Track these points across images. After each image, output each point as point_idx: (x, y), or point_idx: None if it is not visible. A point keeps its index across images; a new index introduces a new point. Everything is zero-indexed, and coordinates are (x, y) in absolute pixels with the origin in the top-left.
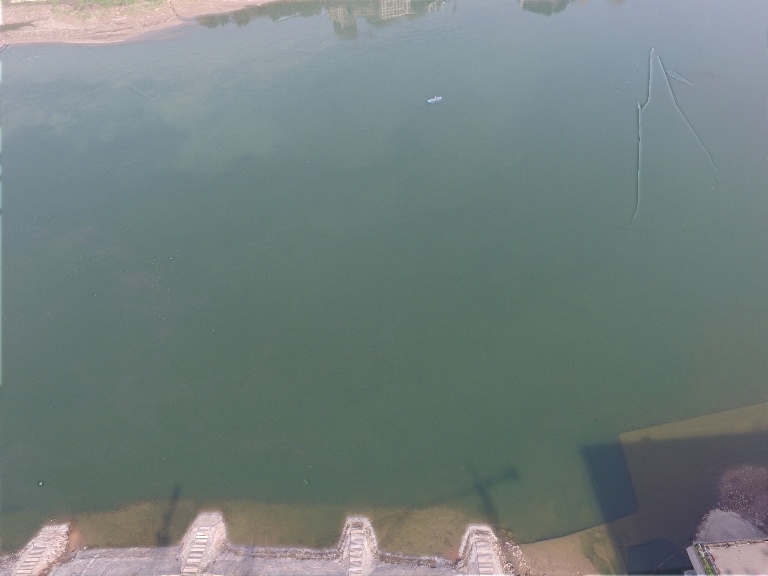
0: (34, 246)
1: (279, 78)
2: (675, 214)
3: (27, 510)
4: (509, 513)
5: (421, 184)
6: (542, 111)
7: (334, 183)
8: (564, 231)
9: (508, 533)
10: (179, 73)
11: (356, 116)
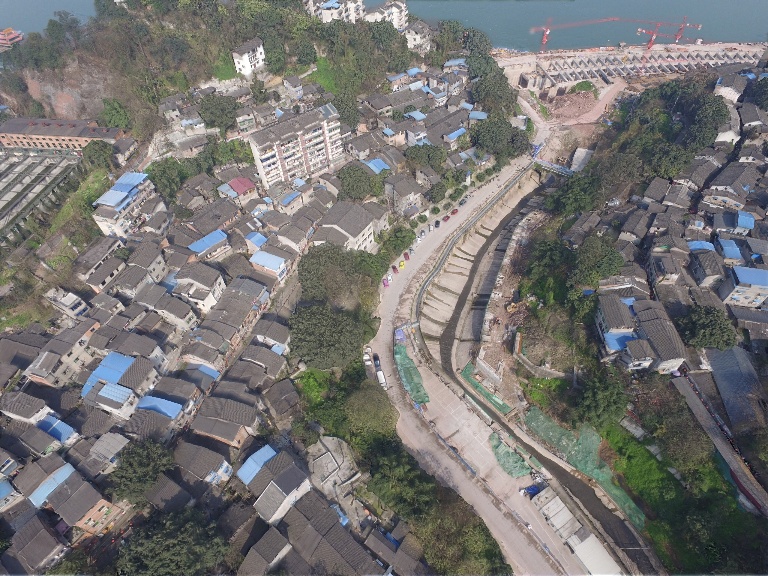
0: None
1: None
2: None
3: (584, 46)
4: None
5: None
6: None
7: None
8: None
9: None
10: None
11: None
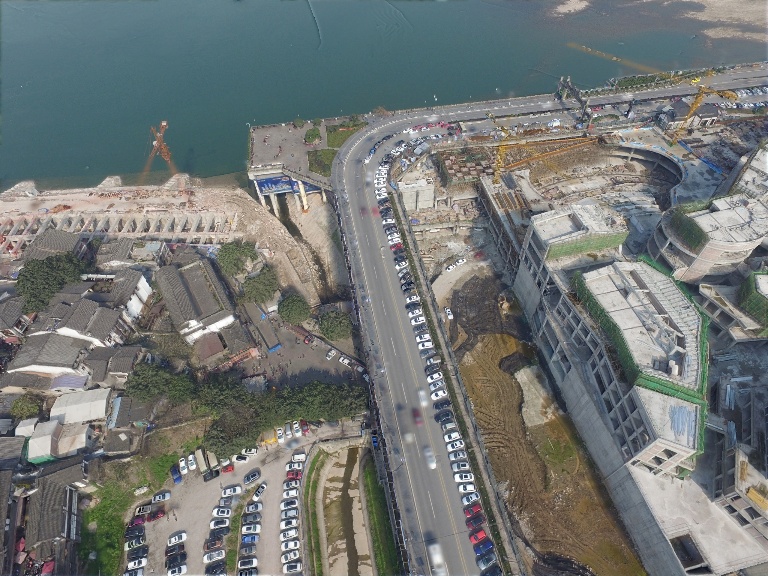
0: None
1: None
2: (354, 38)
3: None
4: (200, 168)
5: (209, 43)
6: None
7: (148, 47)
8: None
9: (197, 175)
10: None
11: (178, 12)
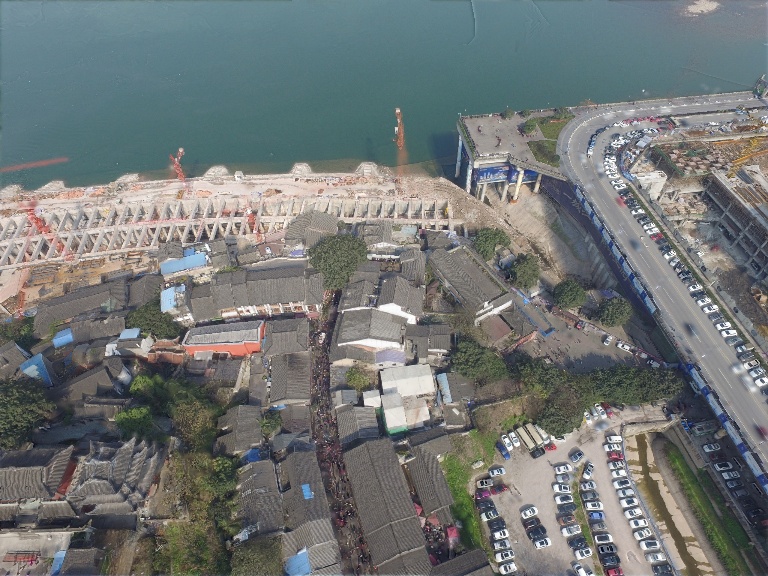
0: (85, 73)
1: None
2: (504, 33)
3: (112, 171)
4: (385, 158)
5: (348, 36)
6: None
7: (288, 38)
8: (431, 40)
9: (383, 164)
10: None
11: (304, 5)
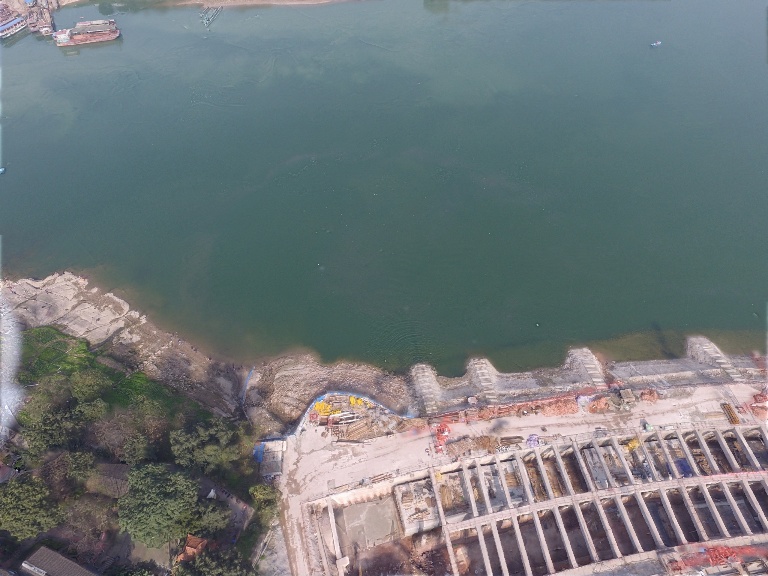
0: (391, 162)
1: (496, 31)
2: None
3: (545, 341)
4: None
5: (692, 109)
6: (760, 51)
7: (613, 111)
8: None
9: None
10: (400, 28)
11: None
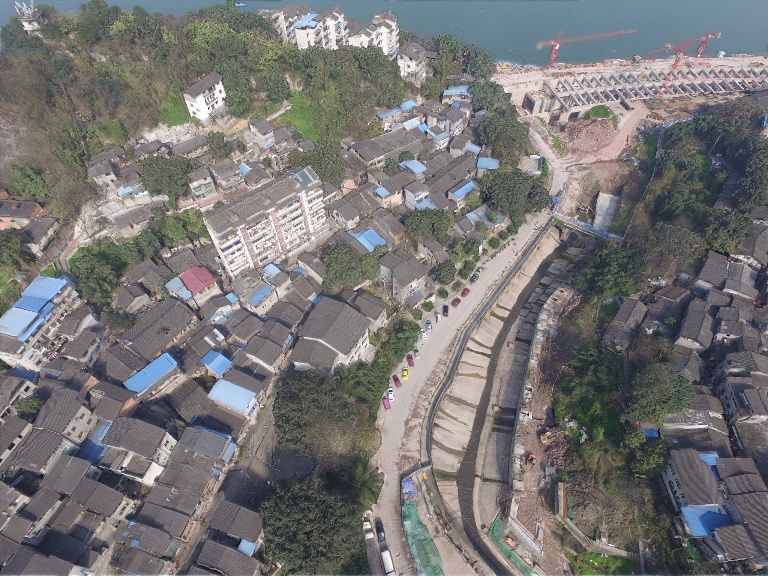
0: None
1: None
2: None
3: None
4: None
5: None
6: None
7: None
8: None
9: None
10: None
11: None
